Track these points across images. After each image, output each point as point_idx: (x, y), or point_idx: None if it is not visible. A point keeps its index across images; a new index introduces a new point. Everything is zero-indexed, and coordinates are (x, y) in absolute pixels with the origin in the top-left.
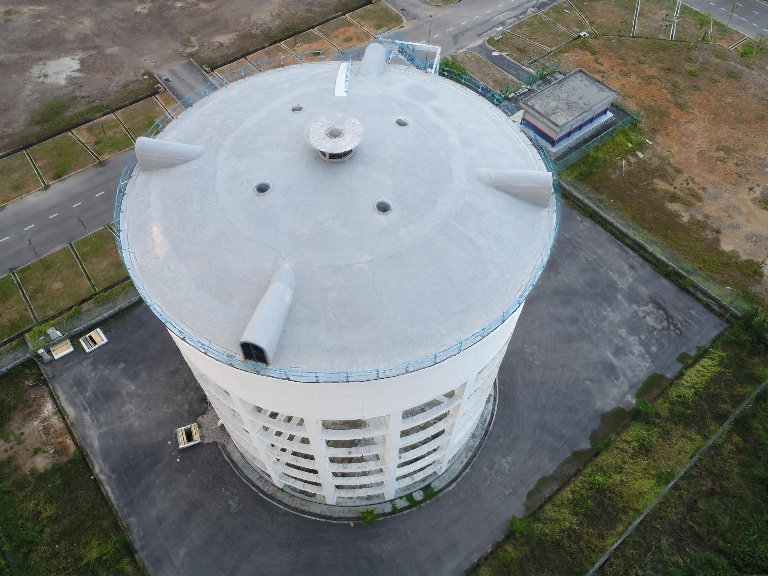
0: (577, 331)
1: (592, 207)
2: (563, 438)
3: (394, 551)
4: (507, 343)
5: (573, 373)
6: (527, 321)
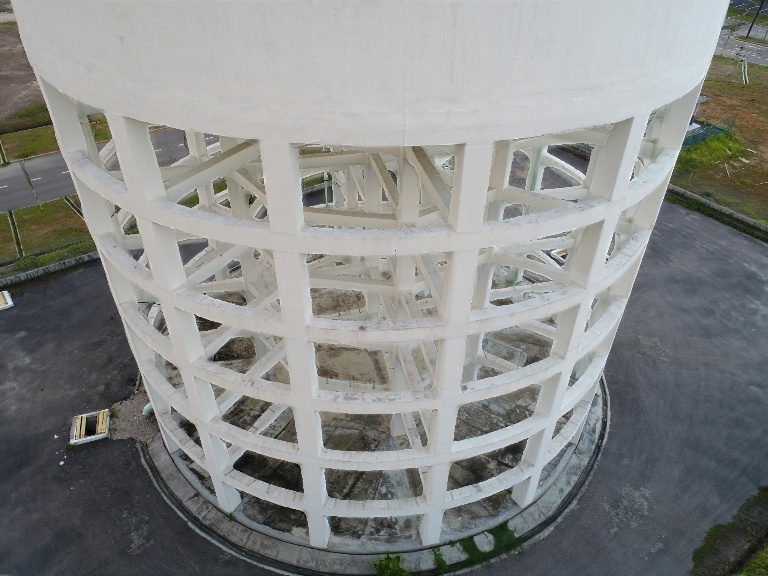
0: (716, 324)
1: (698, 199)
2: (736, 465)
3: None
4: (680, 140)
5: (726, 375)
6: (636, 309)
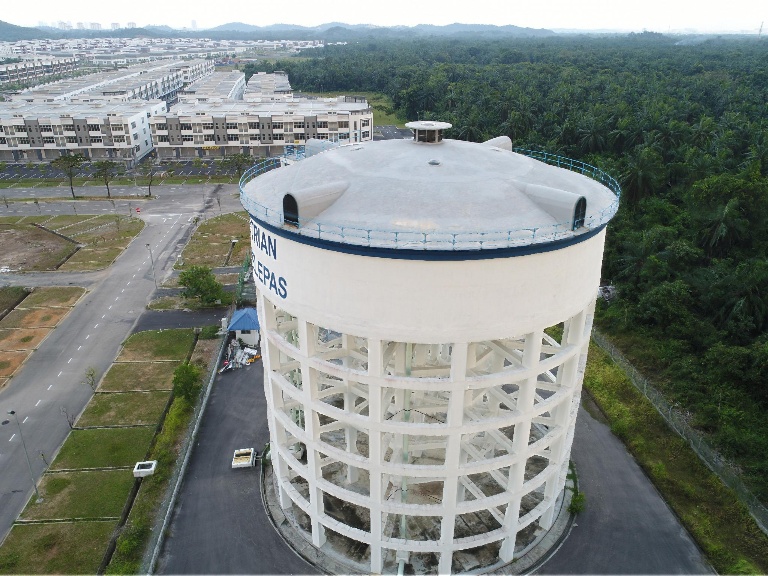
0: None
1: None
2: None
3: (612, 509)
4: None
5: None
6: None
